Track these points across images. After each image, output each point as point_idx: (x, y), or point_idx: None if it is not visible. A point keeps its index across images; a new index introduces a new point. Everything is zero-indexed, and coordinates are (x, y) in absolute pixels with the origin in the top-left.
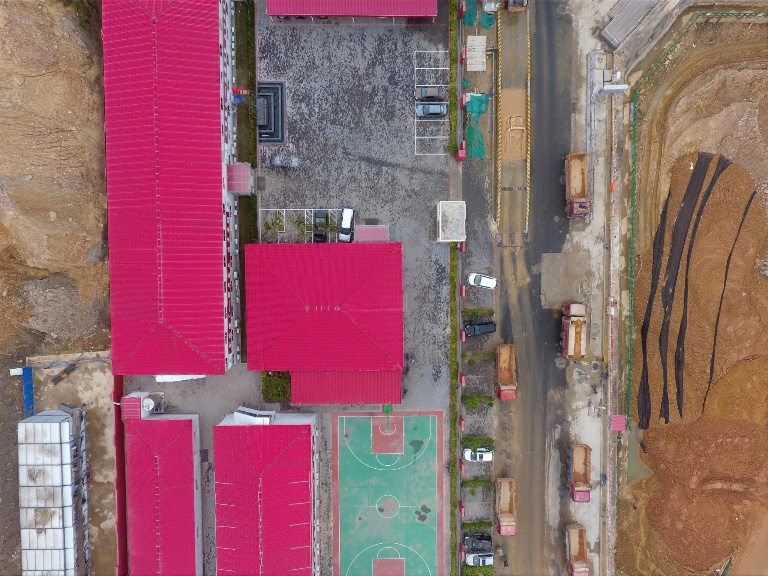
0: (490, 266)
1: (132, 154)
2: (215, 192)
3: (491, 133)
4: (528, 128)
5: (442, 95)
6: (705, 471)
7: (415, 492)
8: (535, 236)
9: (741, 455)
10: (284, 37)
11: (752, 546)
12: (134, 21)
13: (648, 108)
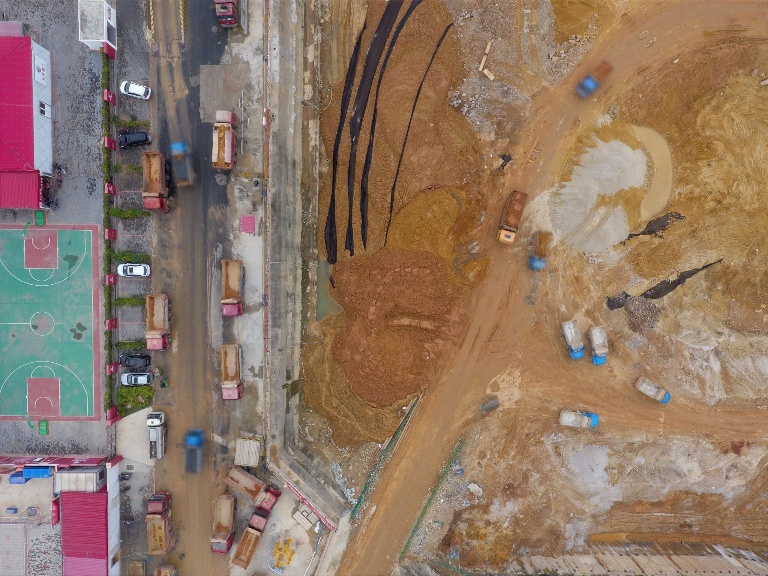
0: (147, 77)
1: None
2: None
3: None
4: None
5: None
6: (387, 303)
7: (70, 309)
8: (193, 47)
9: (424, 288)
10: None
11: (443, 386)
12: None
13: None
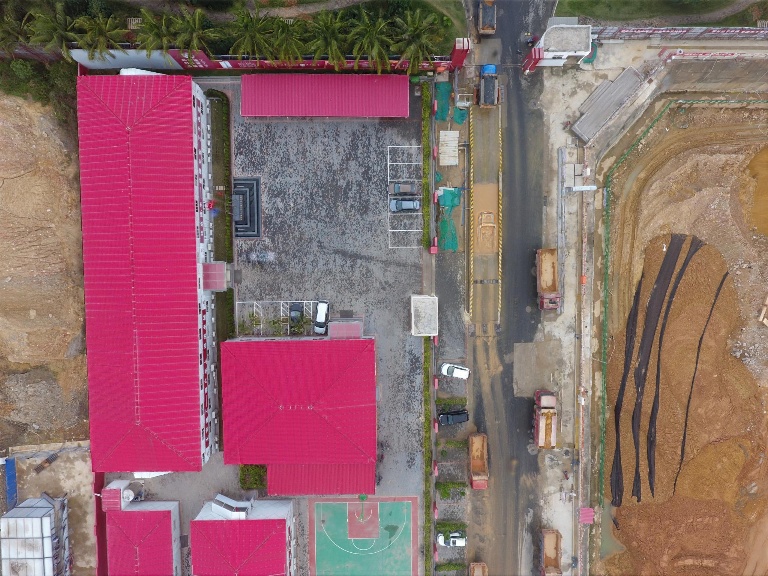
0: (463, 356)
1: (108, 260)
2: (190, 295)
3: (464, 226)
4: (500, 222)
5: (415, 191)
6: (676, 549)
7: (390, 575)
8: (507, 326)
9: (711, 533)
10: (259, 133)
11: None
12: (109, 130)
13: (621, 191)
